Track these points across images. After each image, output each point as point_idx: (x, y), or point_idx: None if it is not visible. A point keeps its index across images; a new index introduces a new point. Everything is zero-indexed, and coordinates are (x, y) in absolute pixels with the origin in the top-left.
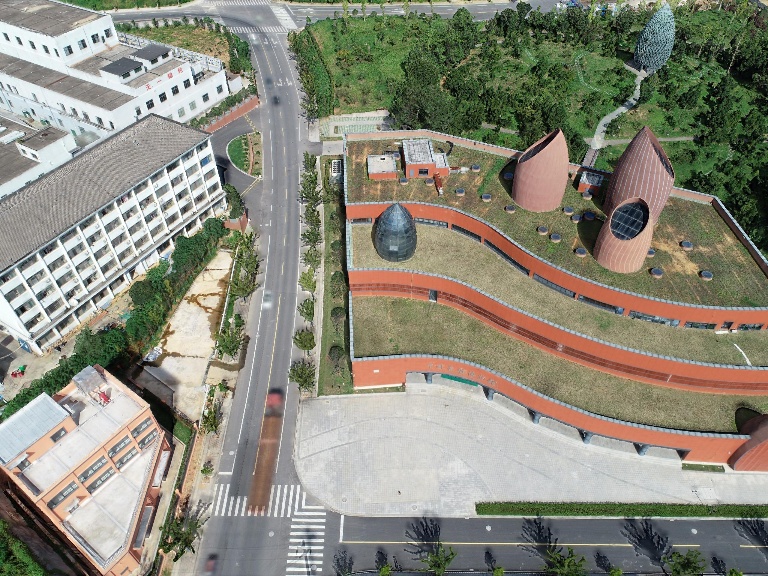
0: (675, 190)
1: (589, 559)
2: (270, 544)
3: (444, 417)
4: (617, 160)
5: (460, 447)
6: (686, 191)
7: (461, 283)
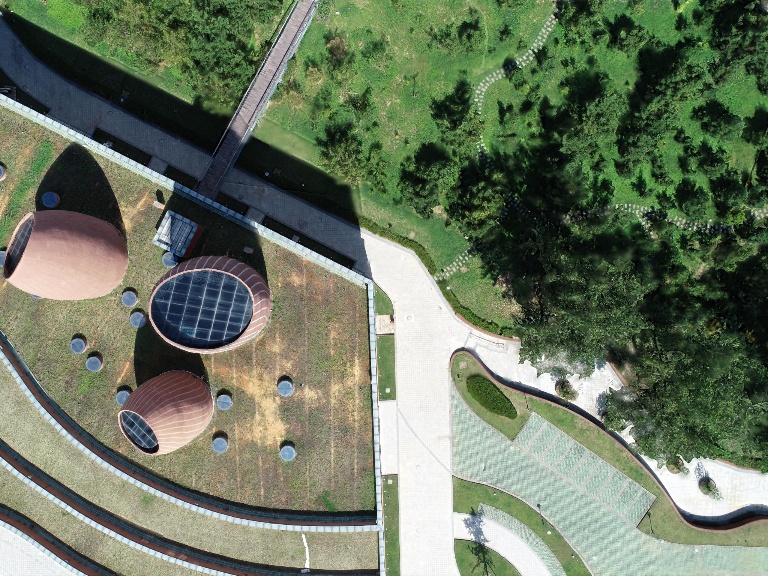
0: (314, 257)
1: None
2: None
3: (2, 529)
4: (332, 48)
5: (17, 567)
6: (329, 264)
7: None
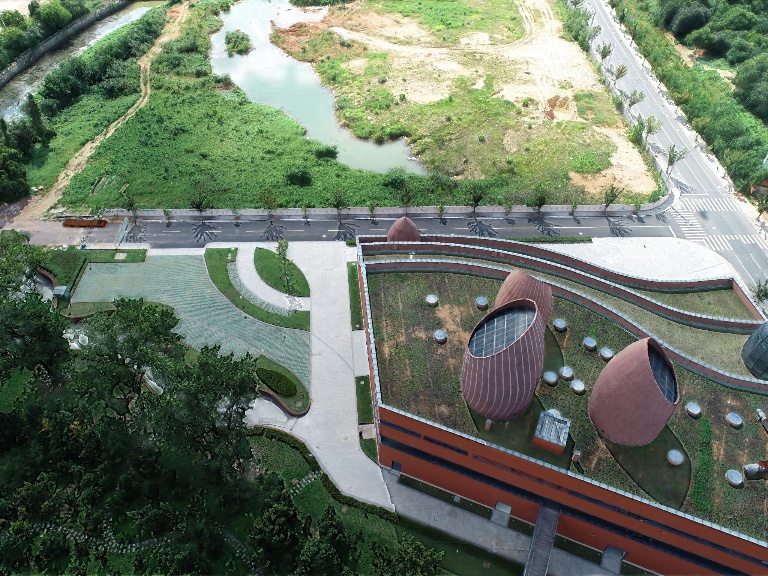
0: None
1: (519, 223)
2: (711, 224)
3: None
4: None
5: None
6: (417, 416)
7: (674, 308)
